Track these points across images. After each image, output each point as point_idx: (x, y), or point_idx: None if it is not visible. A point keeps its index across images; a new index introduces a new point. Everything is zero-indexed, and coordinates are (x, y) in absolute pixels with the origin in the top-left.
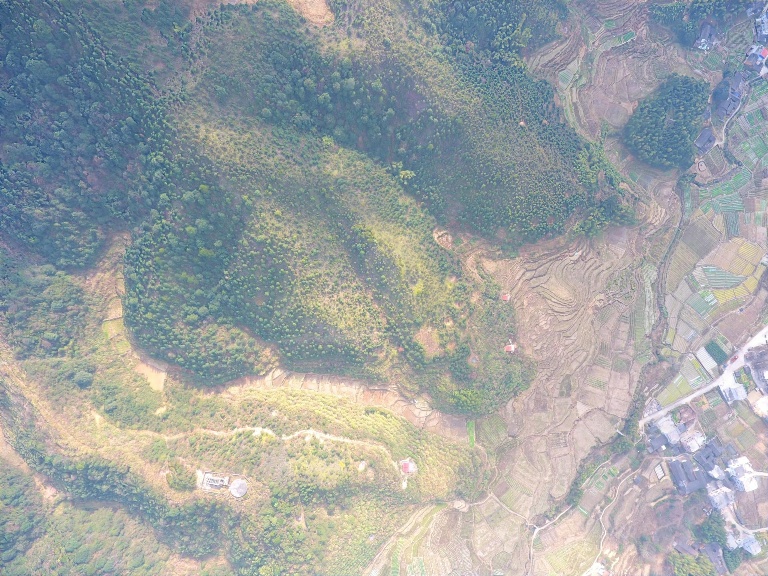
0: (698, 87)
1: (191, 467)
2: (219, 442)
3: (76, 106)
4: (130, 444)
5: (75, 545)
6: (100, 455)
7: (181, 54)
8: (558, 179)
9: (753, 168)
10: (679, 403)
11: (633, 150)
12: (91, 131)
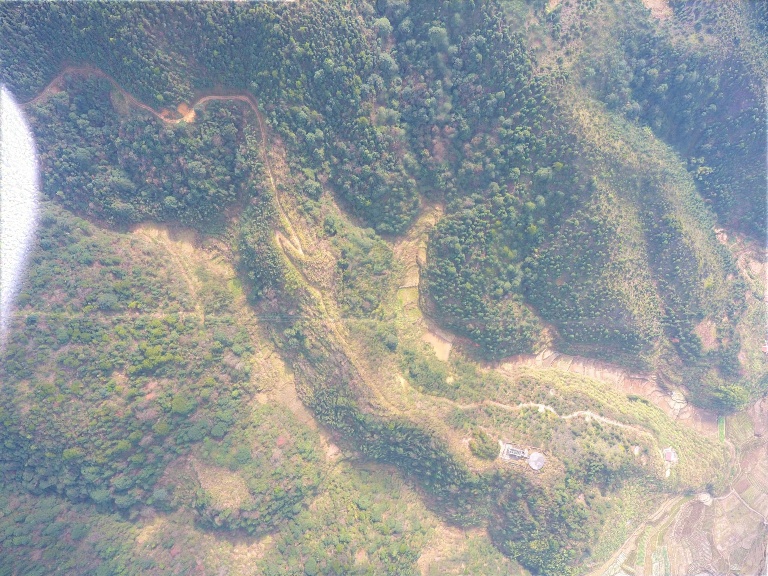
0: None
1: (493, 436)
2: (510, 415)
3: (450, 76)
4: (434, 409)
5: (368, 503)
6: (407, 417)
7: (551, 34)
8: None
9: None
10: None
11: None
12: (451, 101)
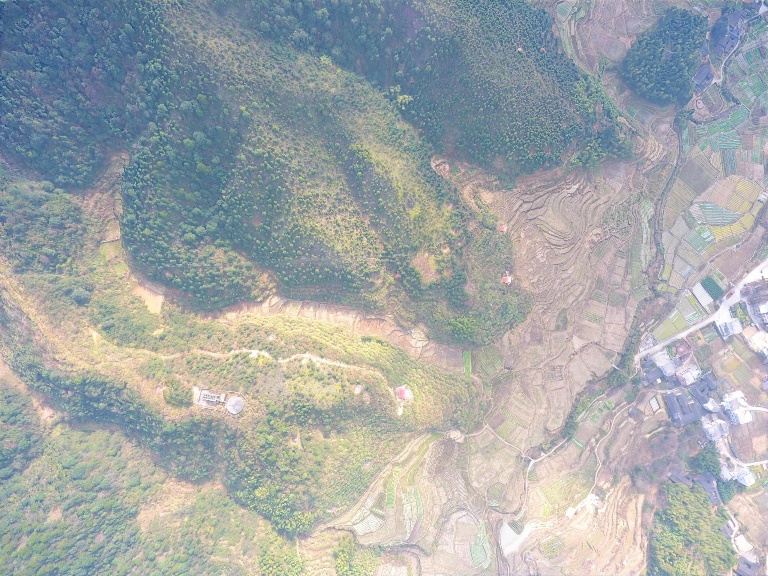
0: (696, 20)
1: (188, 384)
2: (216, 362)
3: (74, 13)
4: (127, 361)
5: (72, 462)
6: (97, 370)
7: None
8: (556, 107)
9: (751, 106)
10: (675, 338)
11: (631, 84)
12: (89, 41)
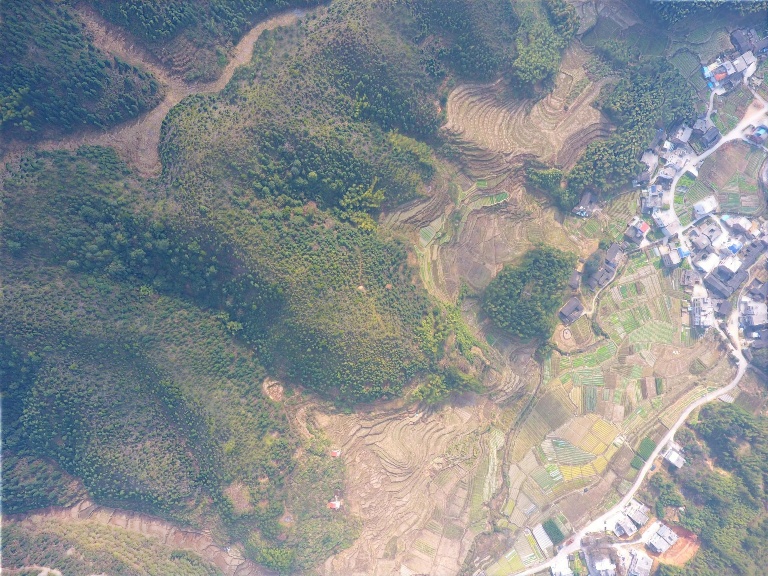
0: (561, 262)
1: None
2: None
3: None
4: None
5: None
6: None
7: None
8: (395, 346)
9: (619, 343)
10: None
11: (489, 315)
12: None
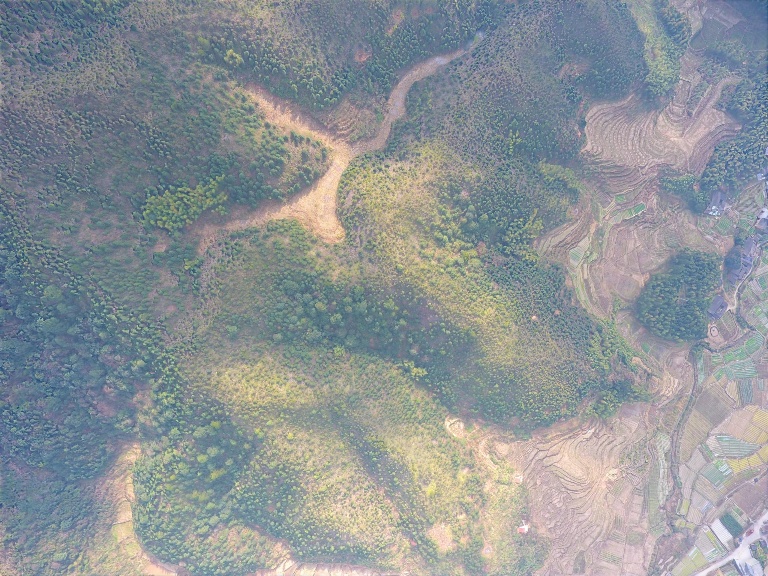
0: (710, 264)
1: None
2: None
3: (86, 348)
4: None
5: None
6: None
7: (192, 291)
8: (571, 369)
9: (766, 333)
10: None
11: (645, 325)
12: (101, 365)
